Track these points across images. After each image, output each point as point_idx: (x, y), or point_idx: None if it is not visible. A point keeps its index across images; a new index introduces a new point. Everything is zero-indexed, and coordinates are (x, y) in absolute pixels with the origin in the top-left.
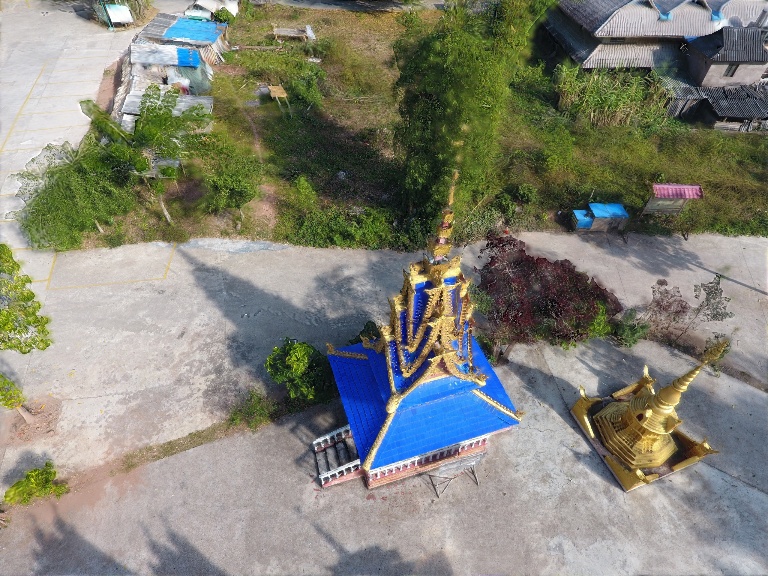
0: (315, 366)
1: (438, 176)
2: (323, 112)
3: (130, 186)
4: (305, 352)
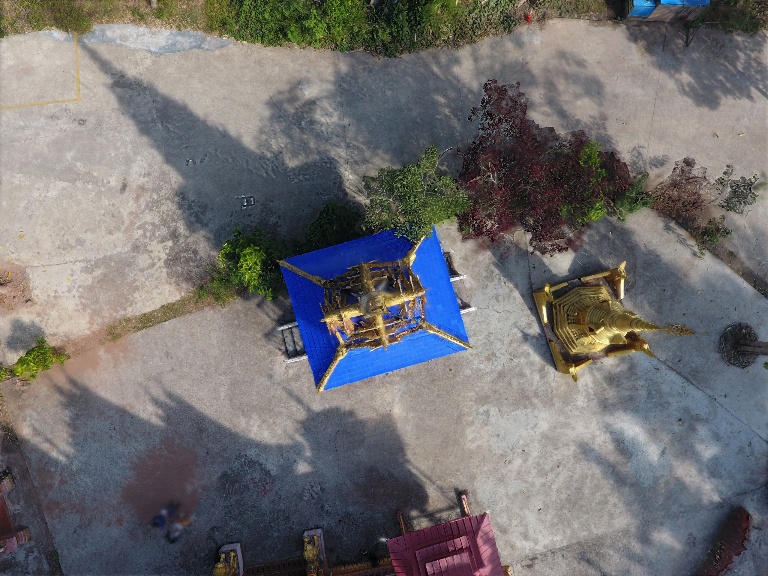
0: (271, 264)
1: None
2: None
3: None
4: (257, 258)
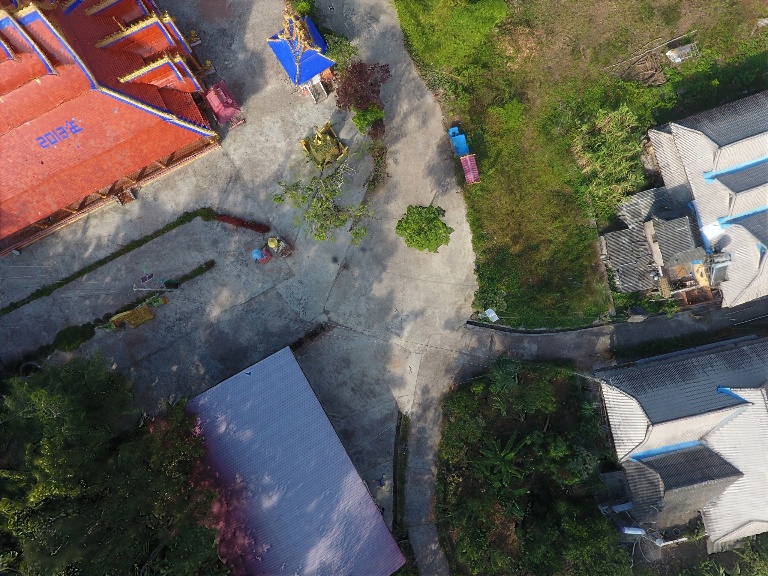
0: None
1: None
2: None
3: None
4: (306, 8)
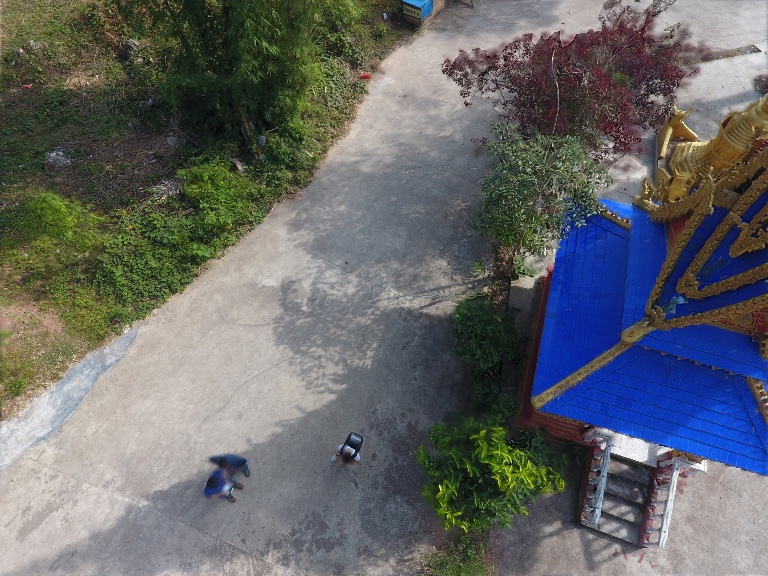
0: None
1: (296, 26)
2: None
3: None
4: None
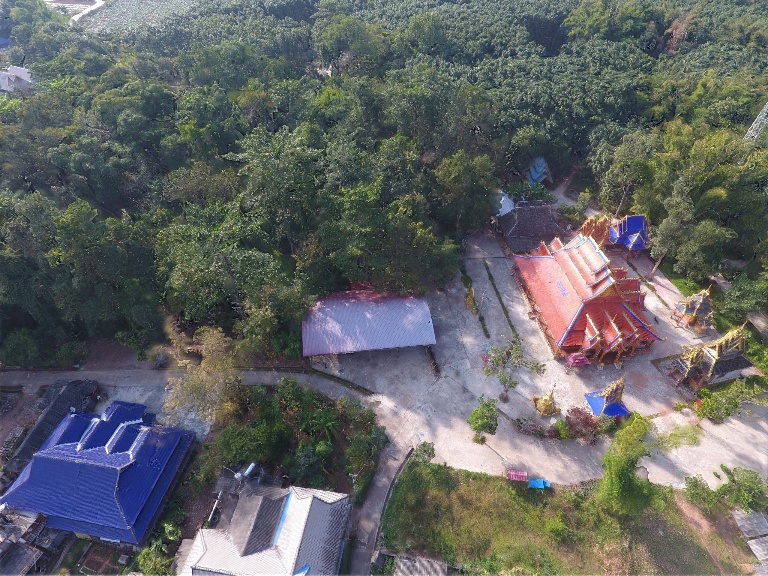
0: None
1: None
2: None
3: None
4: None
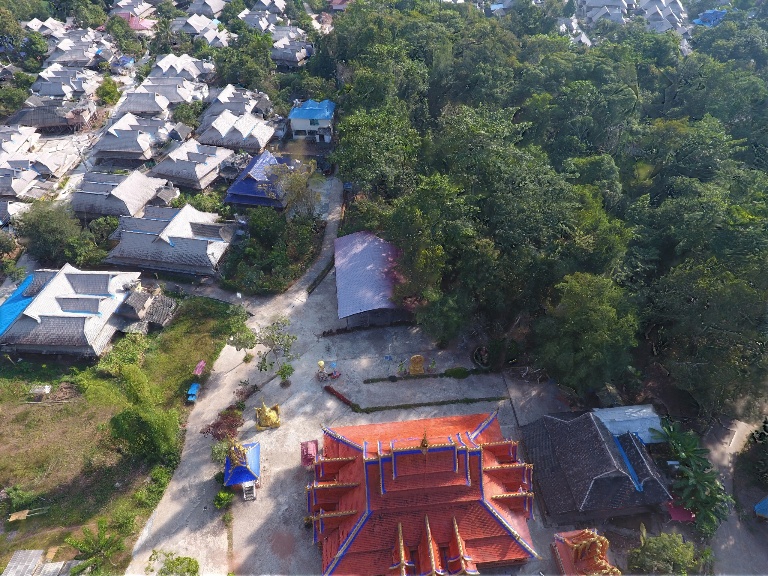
0: None
1: None
2: (52, 491)
3: (102, 572)
4: None
